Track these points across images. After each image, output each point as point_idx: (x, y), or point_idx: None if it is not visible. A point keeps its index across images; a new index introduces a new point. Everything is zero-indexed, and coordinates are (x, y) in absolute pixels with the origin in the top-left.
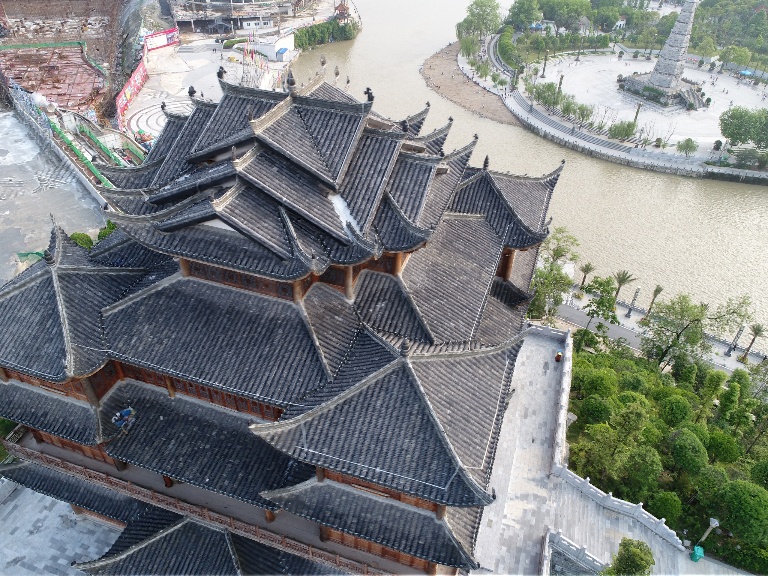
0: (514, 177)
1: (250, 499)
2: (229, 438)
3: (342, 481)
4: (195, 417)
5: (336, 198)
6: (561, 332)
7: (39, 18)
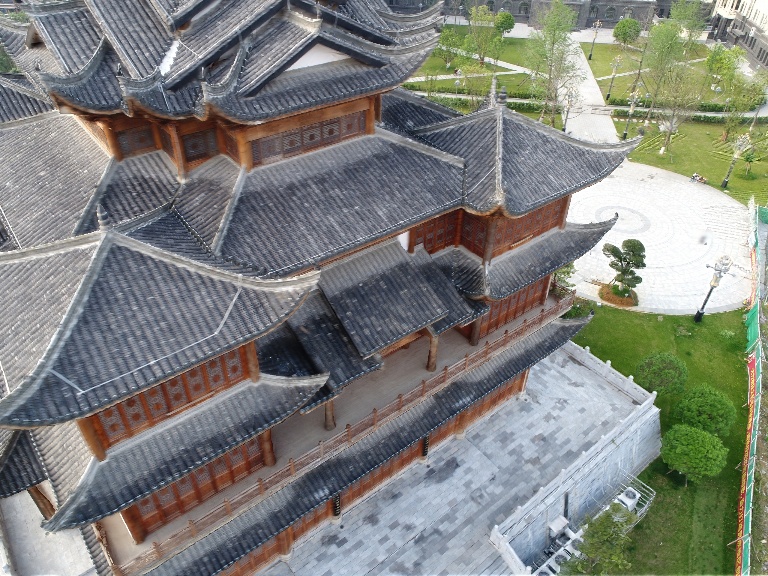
0: None
1: None
2: None
3: None
4: None
5: None
6: None
7: None
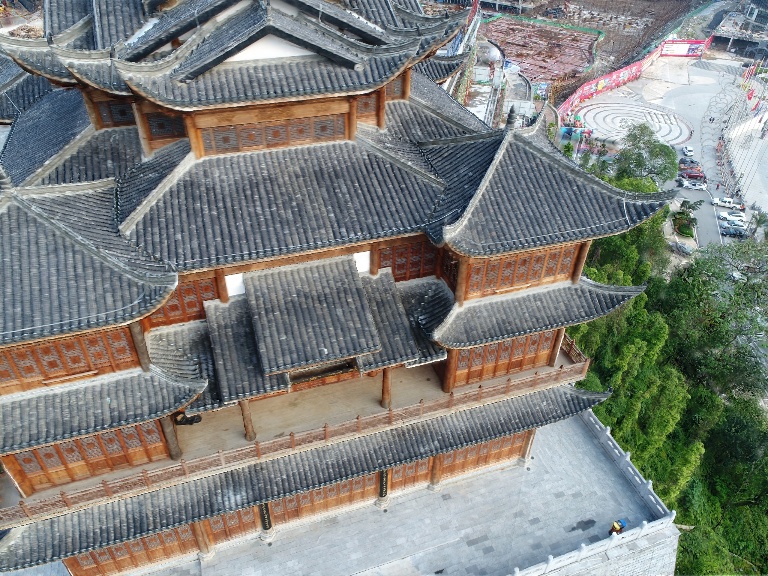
0: (565, 166)
1: None
2: None
3: None
4: None
5: (156, 21)
6: (661, 507)
7: (598, 10)
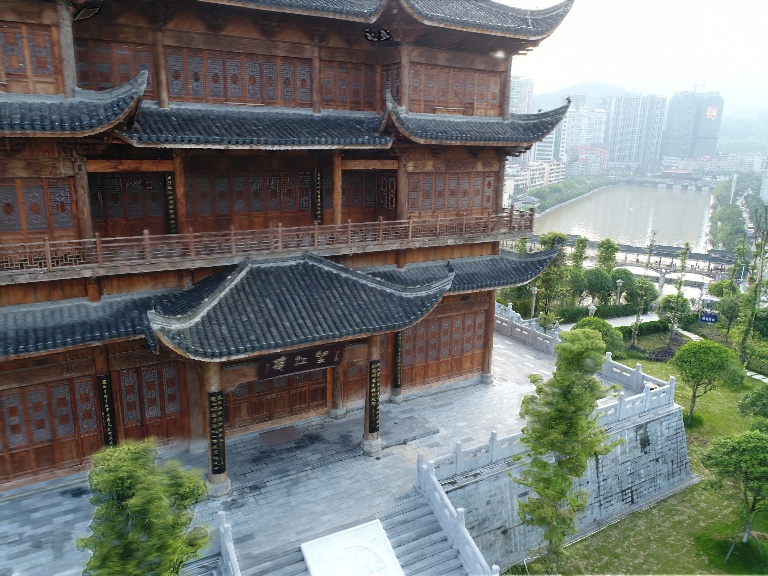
0: None
1: (358, 139)
2: (276, 123)
3: (424, 109)
4: (217, 115)
5: None
6: None
7: None
